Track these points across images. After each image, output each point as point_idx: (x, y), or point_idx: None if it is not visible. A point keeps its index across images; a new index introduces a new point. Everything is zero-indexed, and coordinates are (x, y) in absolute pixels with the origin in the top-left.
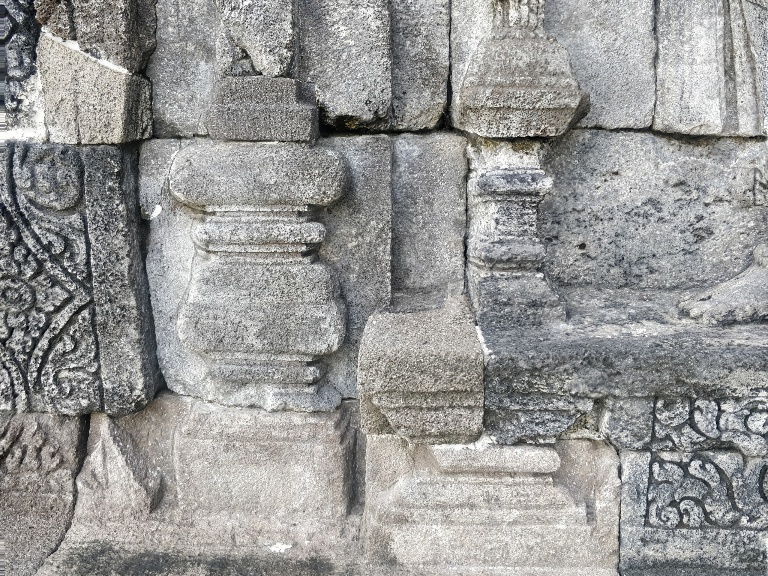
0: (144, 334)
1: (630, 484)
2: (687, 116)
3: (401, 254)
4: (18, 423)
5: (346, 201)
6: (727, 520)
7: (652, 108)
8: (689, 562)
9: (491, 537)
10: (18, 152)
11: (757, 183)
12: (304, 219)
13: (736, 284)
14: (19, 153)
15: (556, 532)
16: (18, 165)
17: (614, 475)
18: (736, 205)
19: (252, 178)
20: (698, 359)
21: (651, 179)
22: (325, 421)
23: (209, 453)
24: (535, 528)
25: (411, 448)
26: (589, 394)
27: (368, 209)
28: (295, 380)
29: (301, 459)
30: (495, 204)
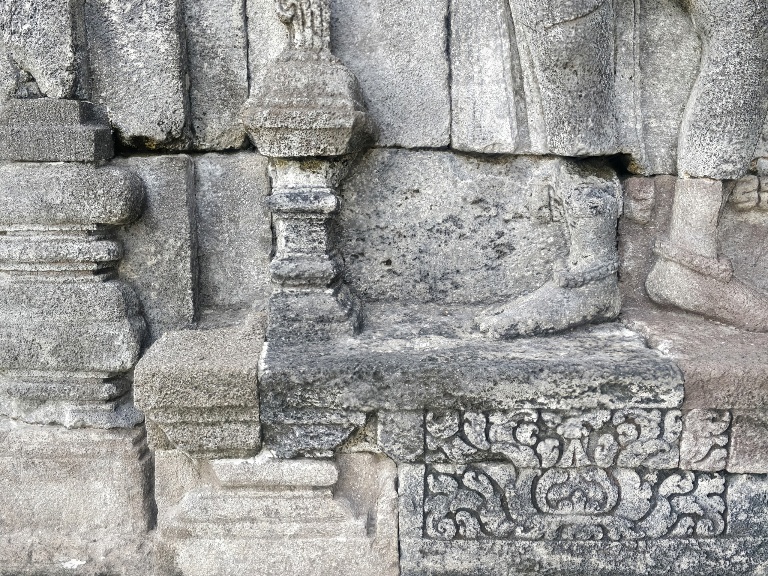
0: None
1: (406, 496)
2: (480, 135)
3: (209, 272)
4: None
5: (143, 220)
6: (502, 531)
7: (448, 127)
8: (468, 573)
9: (273, 550)
10: None
11: (552, 200)
12: (94, 238)
13: (528, 298)
14: None
15: (337, 545)
16: None
17: (390, 487)
18: (534, 221)
19: (39, 198)
20: (463, 372)
21: (450, 196)
22: (123, 437)
23: (9, 470)
24: (316, 541)
25: (195, 463)
26: (360, 408)
27: (166, 228)
28: (91, 397)
29: (100, 475)
30: (283, 222)
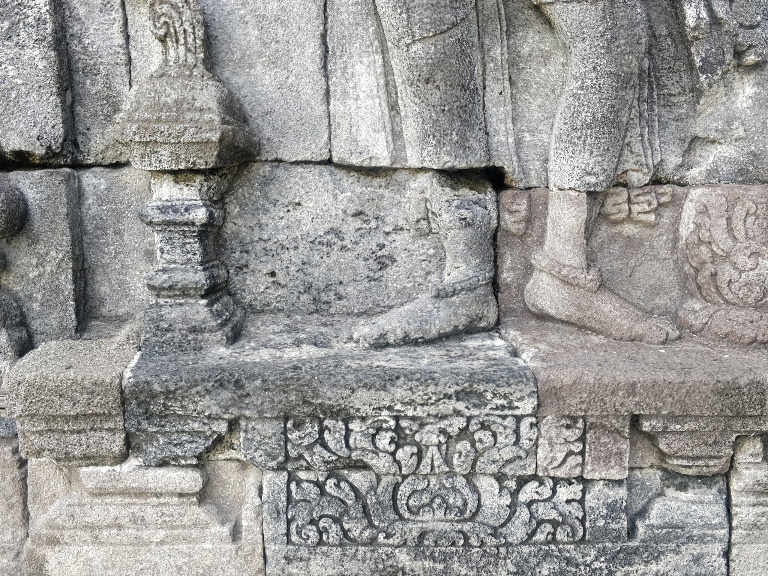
0: None
1: (269, 503)
2: (356, 149)
3: (95, 283)
4: None
5: (24, 232)
6: (365, 537)
7: (327, 142)
8: None
9: (140, 557)
10: None
11: (429, 212)
12: None
13: (402, 309)
14: None
15: (203, 551)
16: None
17: (253, 494)
18: (413, 233)
19: None
20: (321, 380)
21: (331, 209)
22: (3, 446)
23: None
24: (182, 548)
25: (65, 471)
26: (222, 415)
27: (47, 240)
28: None
29: None
30: (157, 234)
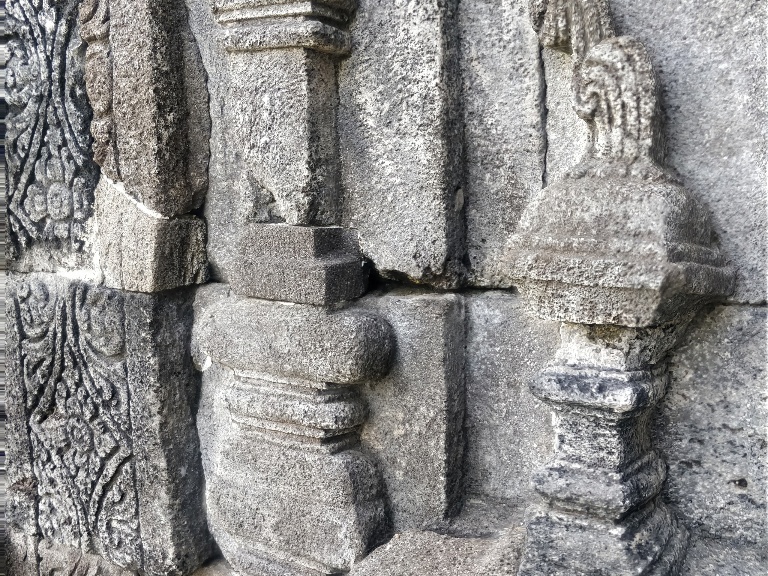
0: (180, 498)
1: None
2: None
3: (479, 449)
4: (85, 562)
5: (392, 377)
6: None
7: None
8: None
9: None
10: (78, 294)
11: None
12: (323, 399)
13: None
14: (80, 295)
15: None
16: (79, 306)
17: None
18: None
19: (268, 343)
20: None
21: None
22: None
23: None
24: None
25: None
26: None
27: (417, 391)
28: None
29: None
30: (556, 414)
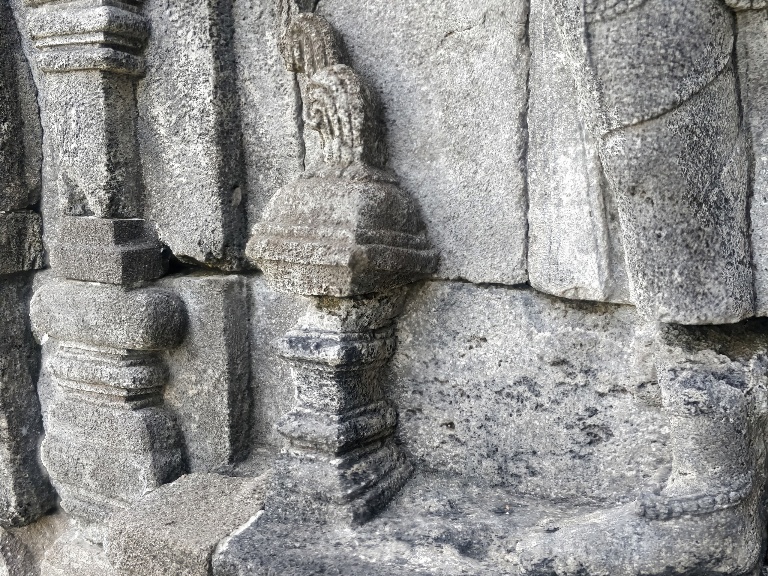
0: (21, 454)
1: None
2: (556, 274)
3: (263, 406)
4: None
5: (186, 345)
6: None
7: (521, 260)
8: None
9: None
10: None
11: None
12: (125, 363)
13: (597, 517)
14: None
15: None
16: None
17: None
18: (638, 401)
19: (81, 317)
20: None
21: (524, 352)
22: None
23: None
24: None
25: None
26: None
27: (205, 356)
28: None
29: None
30: (293, 369)
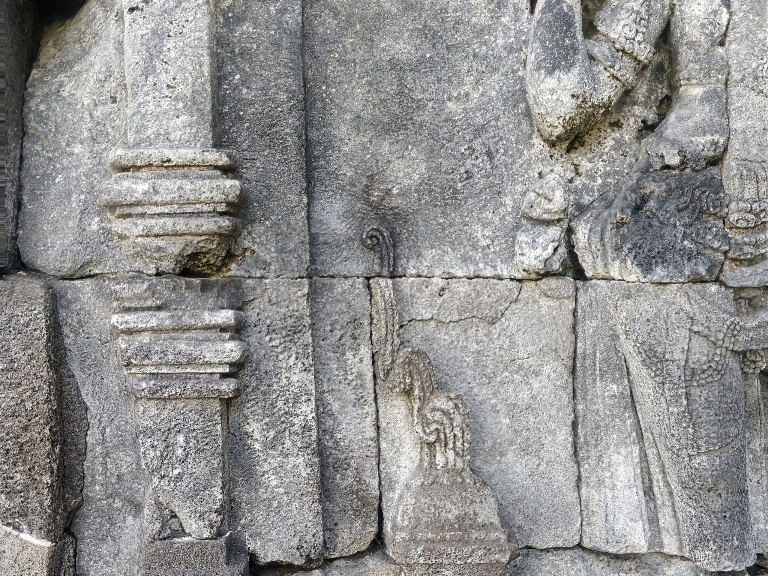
0: None
1: None
2: (613, 538)
3: None
4: None
5: None
6: None
7: (579, 528)
8: None
9: None
10: None
11: None
12: None
13: None
14: None
15: None
16: None
17: None
18: None
19: None
20: None
21: None
22: None
23: None
24: None
25: None
26: None
27: None
28: None
29: None
30: None
